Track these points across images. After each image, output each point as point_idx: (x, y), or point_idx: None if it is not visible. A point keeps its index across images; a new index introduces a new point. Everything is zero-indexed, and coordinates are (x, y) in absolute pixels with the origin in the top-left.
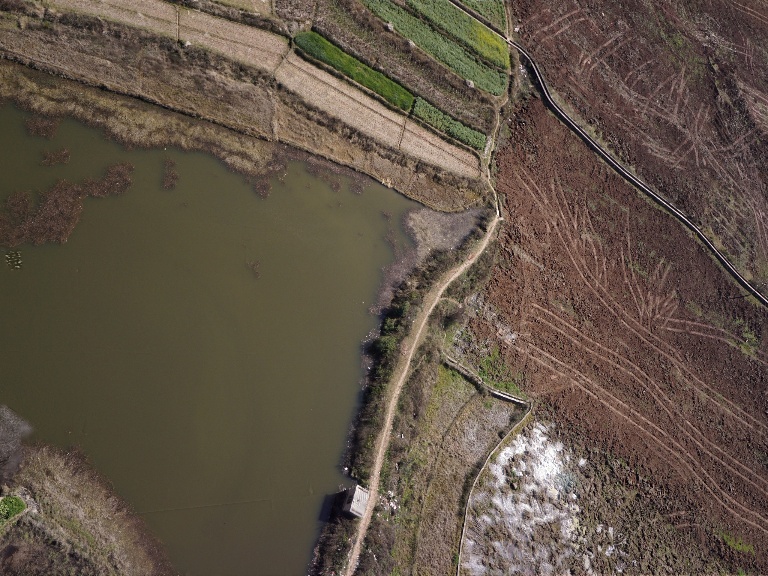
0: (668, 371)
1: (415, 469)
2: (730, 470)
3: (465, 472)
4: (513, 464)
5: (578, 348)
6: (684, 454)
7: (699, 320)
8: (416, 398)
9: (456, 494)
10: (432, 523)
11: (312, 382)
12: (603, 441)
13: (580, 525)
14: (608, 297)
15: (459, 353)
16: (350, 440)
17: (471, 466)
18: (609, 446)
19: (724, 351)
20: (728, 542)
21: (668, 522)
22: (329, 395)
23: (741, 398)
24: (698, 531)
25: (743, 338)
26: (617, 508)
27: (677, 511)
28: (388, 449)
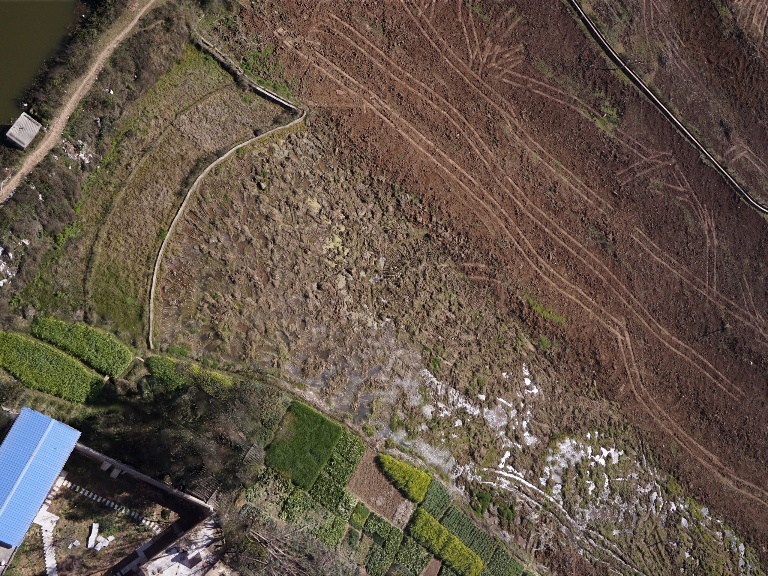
0: (495, 122)
1: (129, 135)
2: (553, 238)
3: (198, 156)
4: (266, 165)
5: (380, 71)
6: (497, 209)
7: (547, 81)
8: (138, 58)
9: (180, 174)
10: (140, 193)
11: (1, 10)
12: (393, 172)
13: (342, 245)
14: (431, 30)
15: (219, 39)
16: (38, 79)
17: (208, 152)
18: (400, 178)
19: (573, 119)
20: (534, 307)
21: (461, 271)
22: (22, 29)
23: (584, 171)
24: (498, 288)
25: (600, 112)
26: (396, 241)
27: (475, 262)
28: (86, 97)
